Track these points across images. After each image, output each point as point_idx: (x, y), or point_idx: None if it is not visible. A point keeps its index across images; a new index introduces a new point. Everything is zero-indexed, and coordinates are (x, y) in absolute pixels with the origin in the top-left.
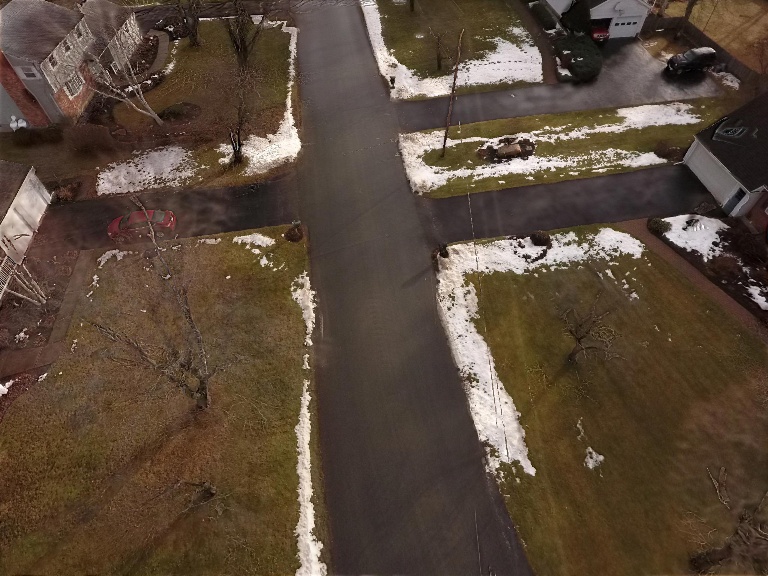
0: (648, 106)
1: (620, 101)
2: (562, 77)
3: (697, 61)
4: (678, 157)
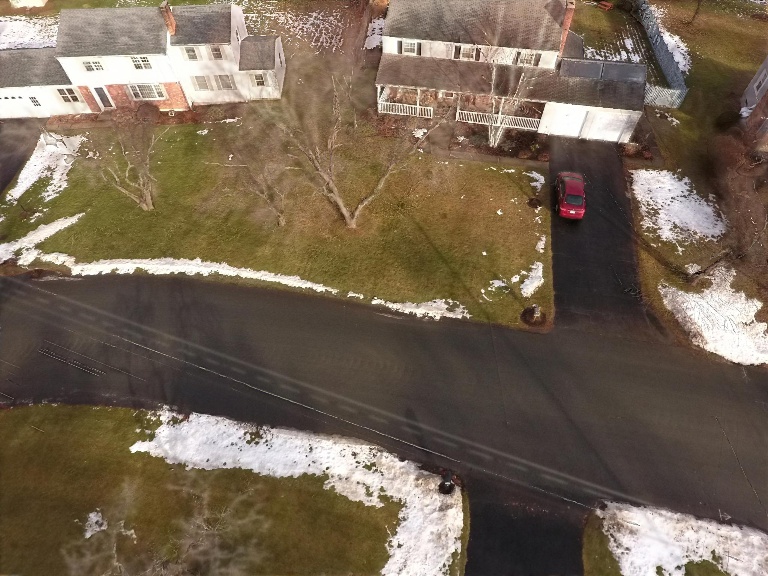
0: None
1: None
2: None
3: None
4: None
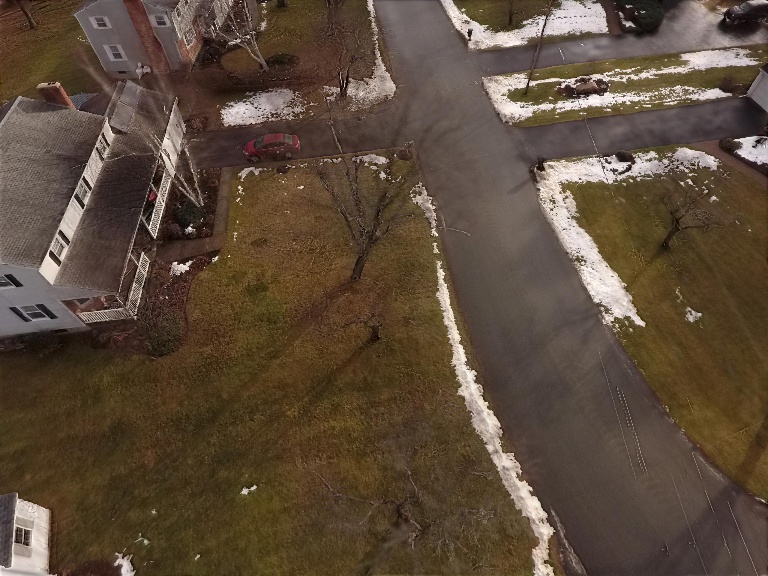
0: (709, 51)
1: (683, 47)
2: (627, 28)
3: (753, 12)
4: (742, 91)
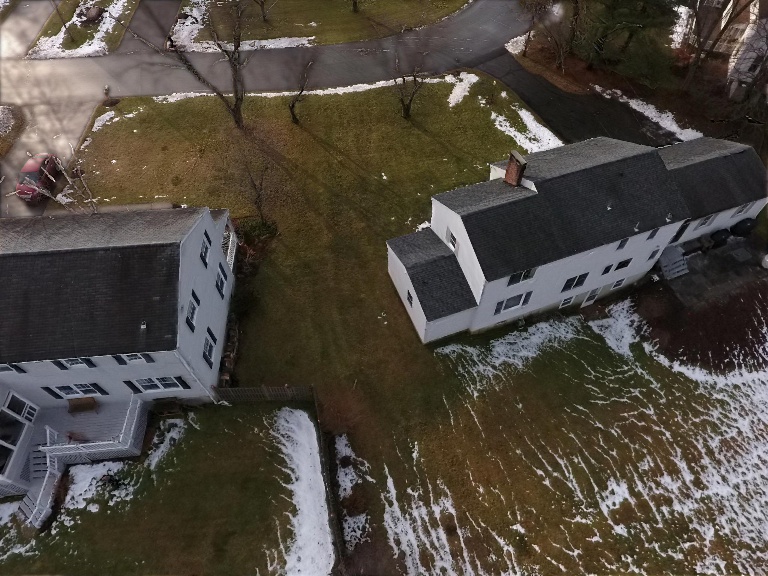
0: None
1: None
2: None
3: None
4: None
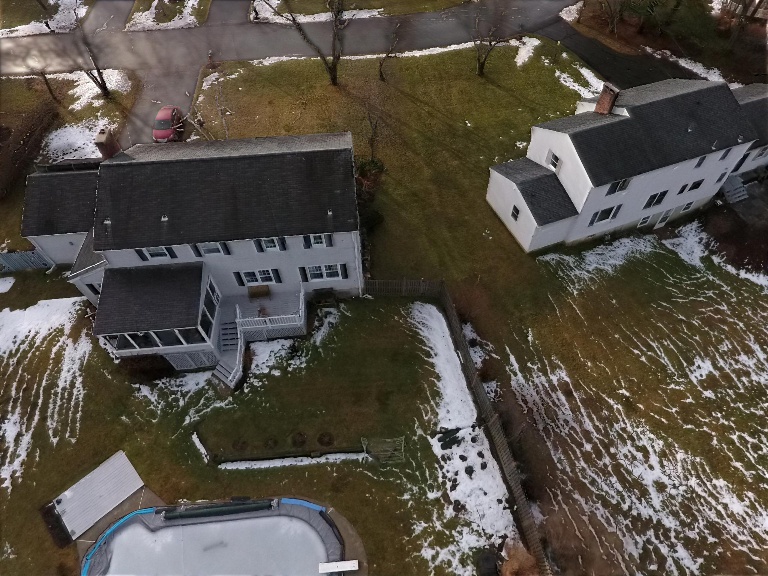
0: None
1: None
2: None
3: None
4: None
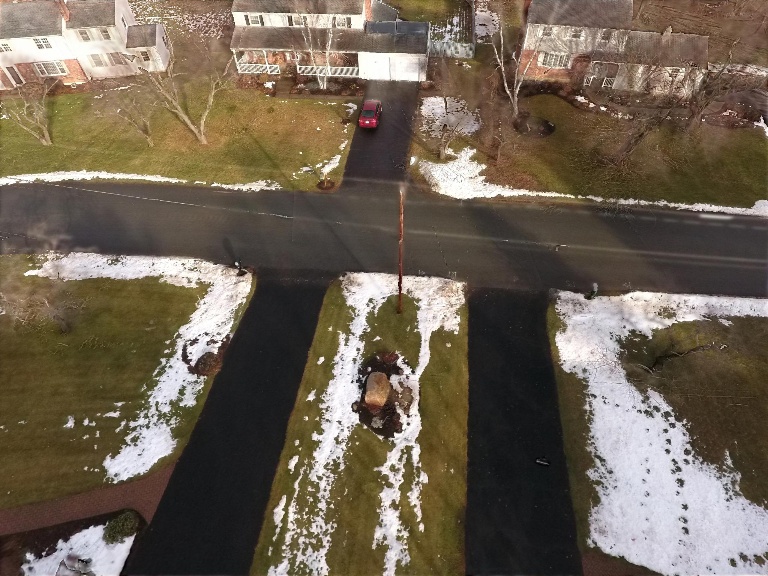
0: None
1: None
2: None
3: None
4: None
